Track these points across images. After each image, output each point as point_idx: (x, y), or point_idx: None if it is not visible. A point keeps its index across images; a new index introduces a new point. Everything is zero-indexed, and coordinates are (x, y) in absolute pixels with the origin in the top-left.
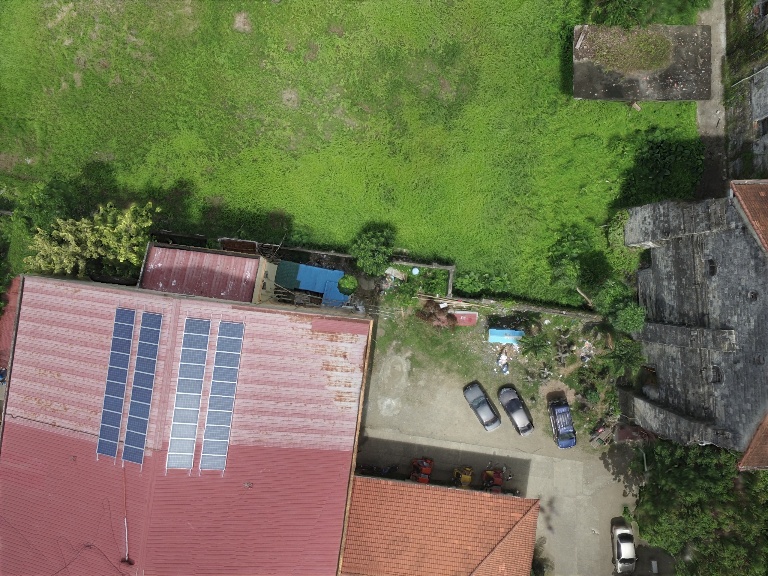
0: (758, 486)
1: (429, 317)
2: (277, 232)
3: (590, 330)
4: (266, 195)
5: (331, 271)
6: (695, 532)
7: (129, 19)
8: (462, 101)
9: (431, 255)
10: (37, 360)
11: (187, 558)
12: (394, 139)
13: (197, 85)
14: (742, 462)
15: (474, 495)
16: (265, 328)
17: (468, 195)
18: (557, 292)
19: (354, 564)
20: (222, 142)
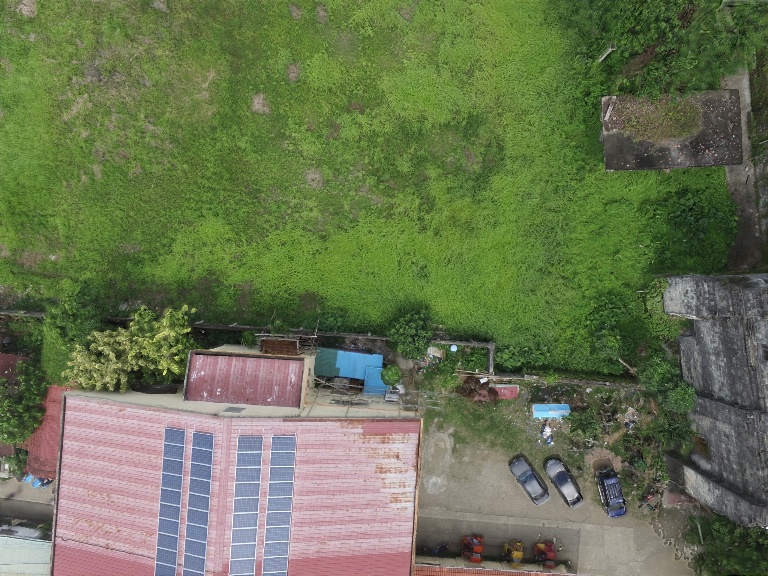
0: None
1: (470, 393)
2: (310, 315)
3: (632, 396)
4: (297, 279)
5: (370, 356)
6: None
7: (146, 107)
8: (489, 172)
9: (468, 331)
10: (85, 481)
11: None
12: (423, 214)
13: (220, 171)
14: None
15: None
16: (317, 437)
17: (502, 267)
18: (598, 361)
19: None
20: (249, 227)
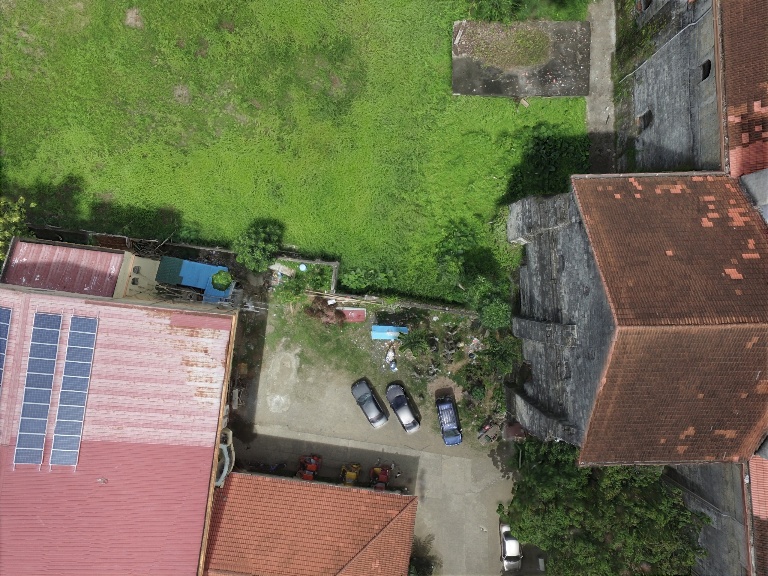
0: (604, 482)
1: (316, 313)
2: (167, 228)
3: (478, 327)
4: (155, 191)
5: (215, 267)
6: (551, 529)
7: (21, 15)
8: (352, 97)
9: (318, 251)
10: None
11: (37, 554)
12: (284, 135)
13: (88, 81)
14: (580, 458)
15: (351, 492)
16: (121, 323)
17: (356, 191)
18: (443, 288)
19: (222, 561)
20: (113, 138)
